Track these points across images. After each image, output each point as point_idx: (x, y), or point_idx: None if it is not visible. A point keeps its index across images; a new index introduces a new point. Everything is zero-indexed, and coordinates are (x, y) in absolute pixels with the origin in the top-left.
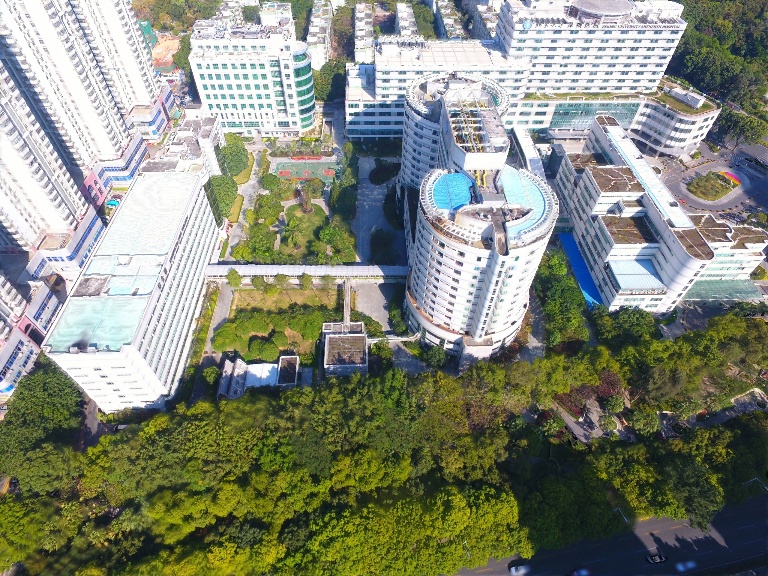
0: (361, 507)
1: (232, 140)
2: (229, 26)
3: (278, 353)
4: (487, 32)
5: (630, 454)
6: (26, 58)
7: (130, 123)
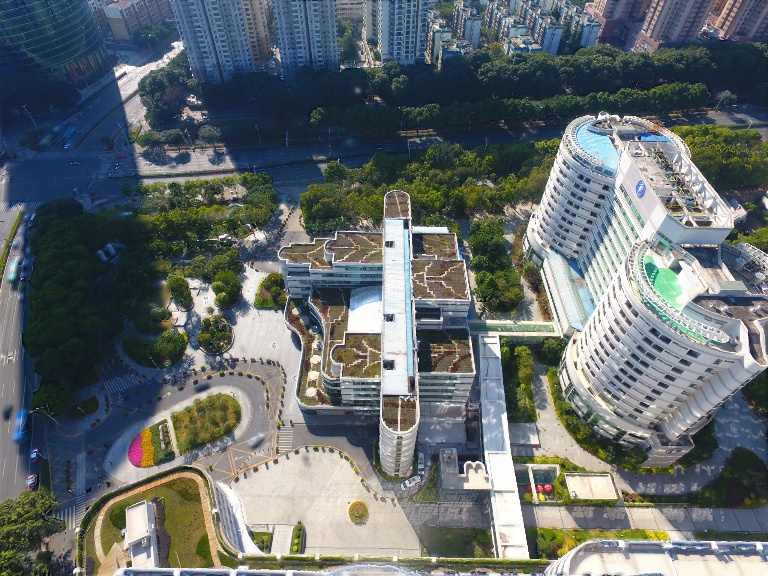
0: None
1: None
2: None
3: None
4: None
5: (467, 168)
6: None
7: None
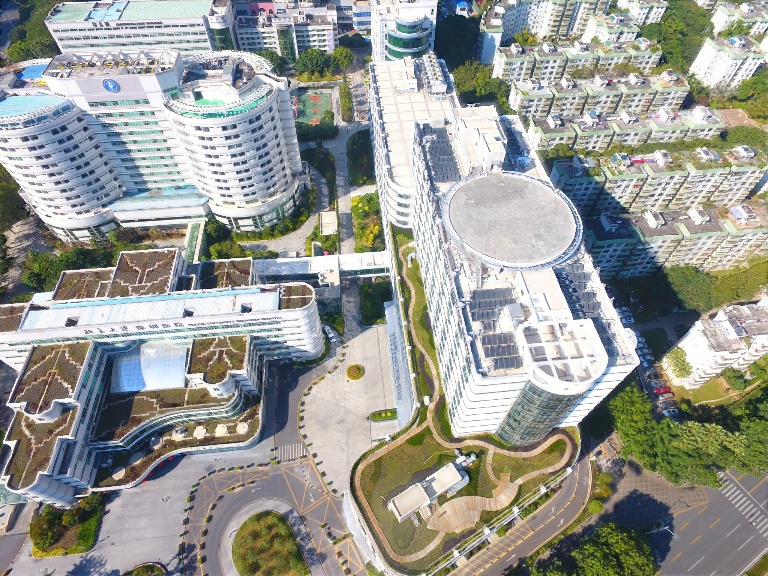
0: None
1: (337, 54)
2: None
3: None
4: (669, 213)
5: None
6: None
7: (348, 5)
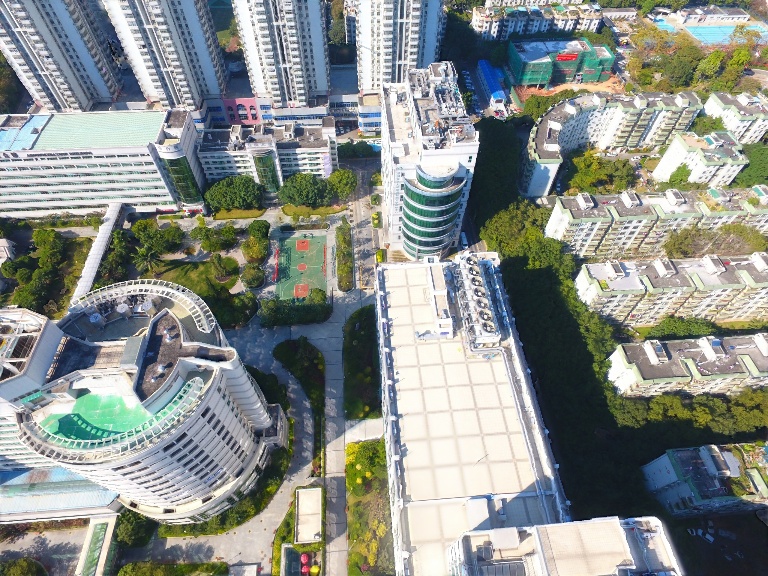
0: None
1: (335, 180)
2: (434, 87)
3: (8, 277)
4: None
5: None
6: None
7: (352, 101)
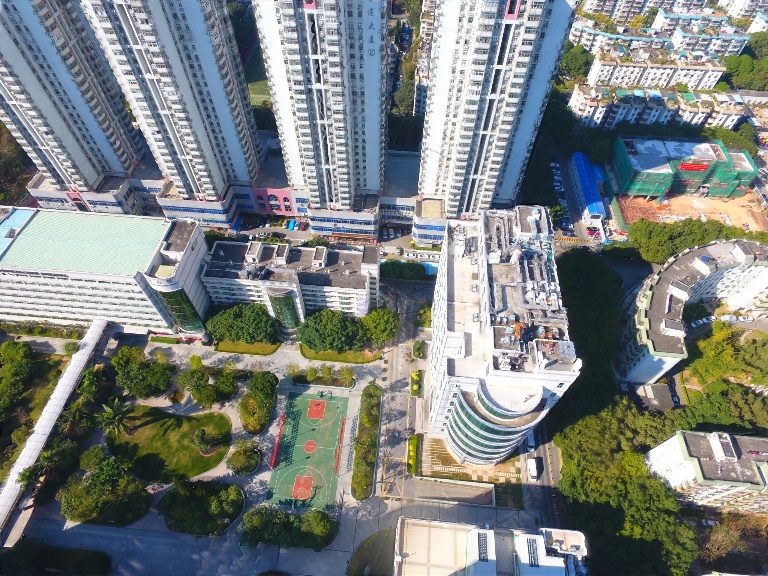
0: None
1: (370, 323)
2: (519, 254)
3: None
4: None
5: None
6: (271, 68)
7: (408, 204)
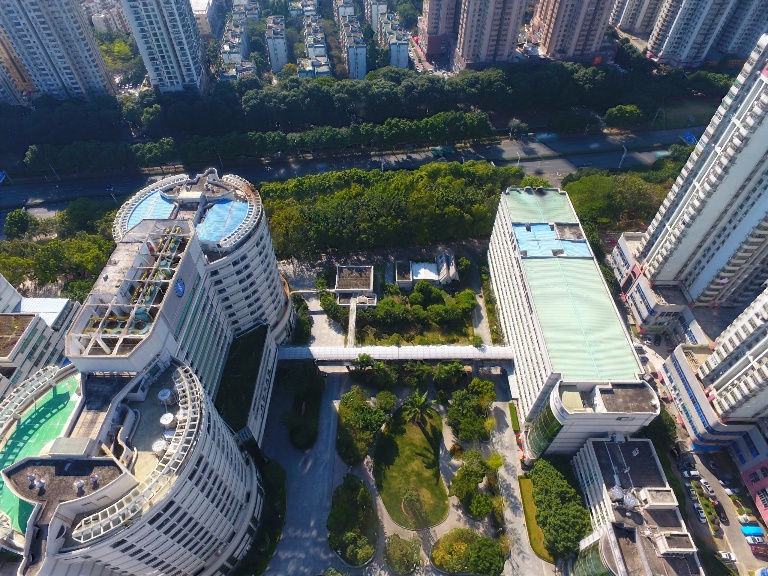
0: (348, 185)
1: None
2: None
3: None
4: None
5: None
6: None
7: None
